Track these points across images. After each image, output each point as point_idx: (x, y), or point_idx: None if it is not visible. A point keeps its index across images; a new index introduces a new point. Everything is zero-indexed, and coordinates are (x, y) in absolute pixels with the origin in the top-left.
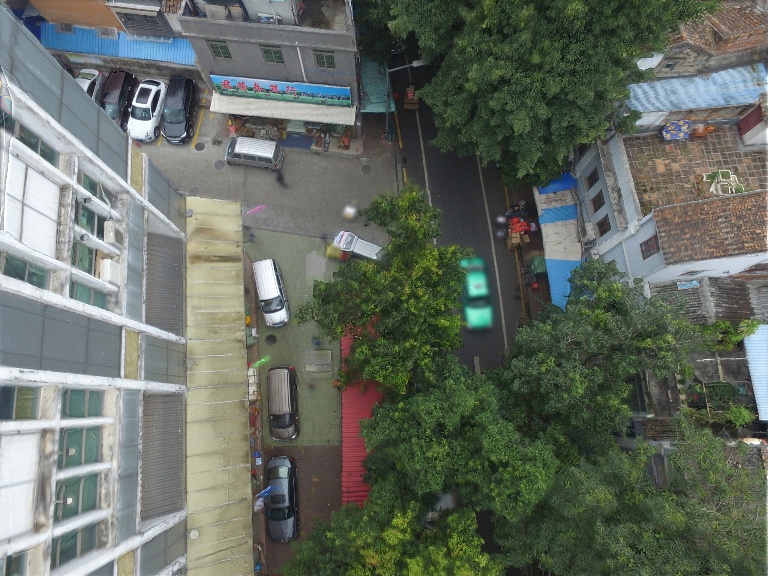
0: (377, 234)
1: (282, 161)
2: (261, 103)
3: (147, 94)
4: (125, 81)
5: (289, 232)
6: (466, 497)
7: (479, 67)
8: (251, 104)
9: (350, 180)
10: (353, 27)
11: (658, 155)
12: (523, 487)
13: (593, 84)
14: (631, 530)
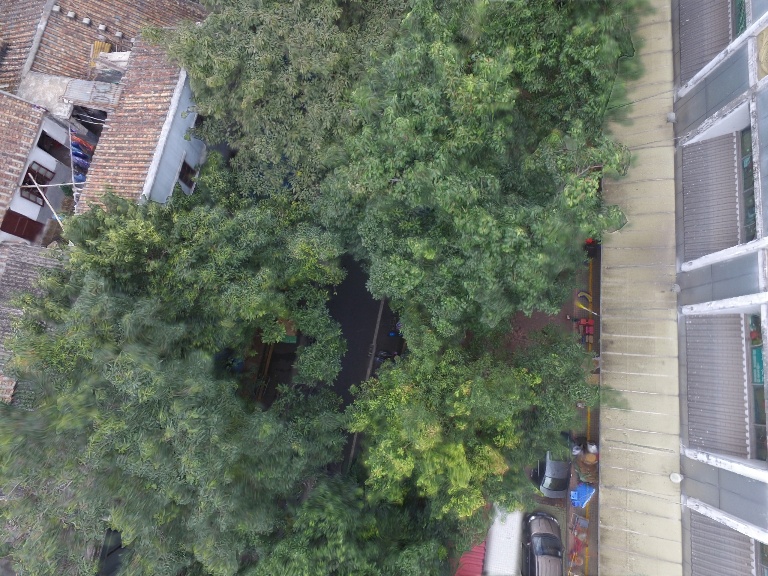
0: None
1: None
2: None
3: None
4: None
5: None
6: (369, 503)
7: None
8: None
9: None
10: None
11: None
12: (306, 574)
13: None
14: (185, 499)
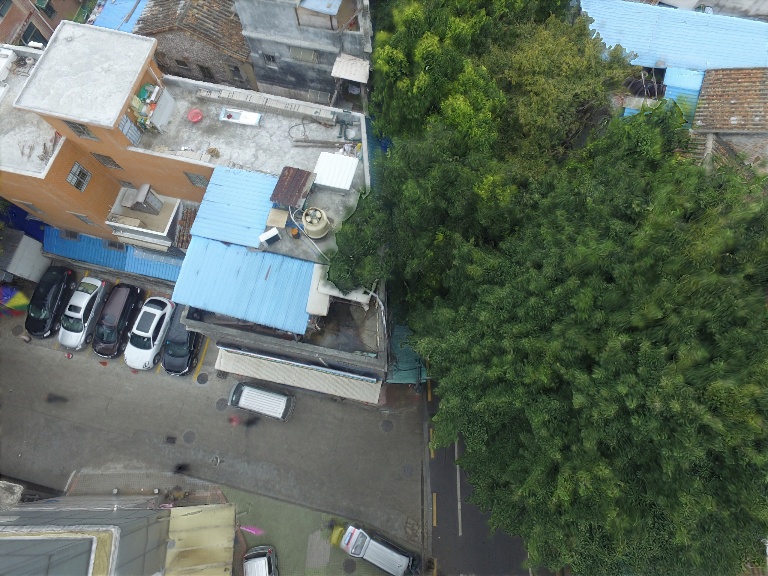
0: (393, 514)
1: (292, 411)
2: (273, 366)
3: (150, 321)
4: (128, 299)
5: (292, 502)
6: None
7: (542, 529)
8: (262, 366)
9: (368, 438)
10: (385, 338)
11: (757, 572)
12: None
13: (693, 569)
14: None
